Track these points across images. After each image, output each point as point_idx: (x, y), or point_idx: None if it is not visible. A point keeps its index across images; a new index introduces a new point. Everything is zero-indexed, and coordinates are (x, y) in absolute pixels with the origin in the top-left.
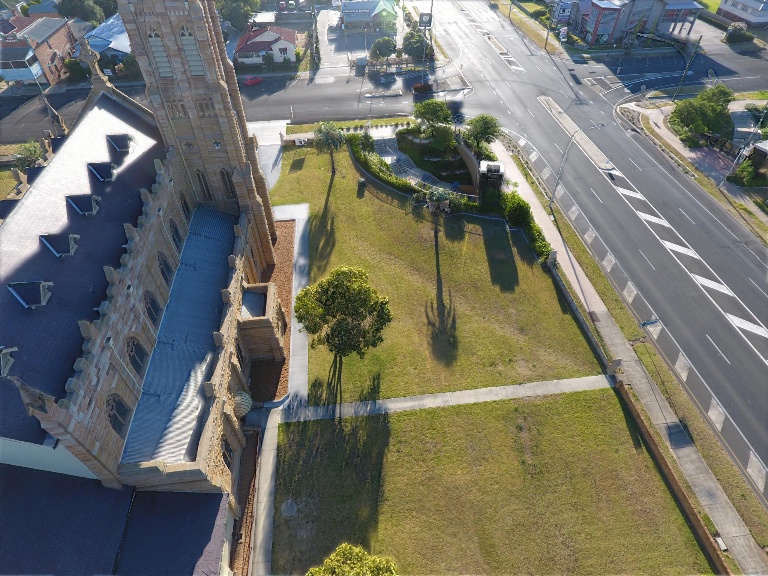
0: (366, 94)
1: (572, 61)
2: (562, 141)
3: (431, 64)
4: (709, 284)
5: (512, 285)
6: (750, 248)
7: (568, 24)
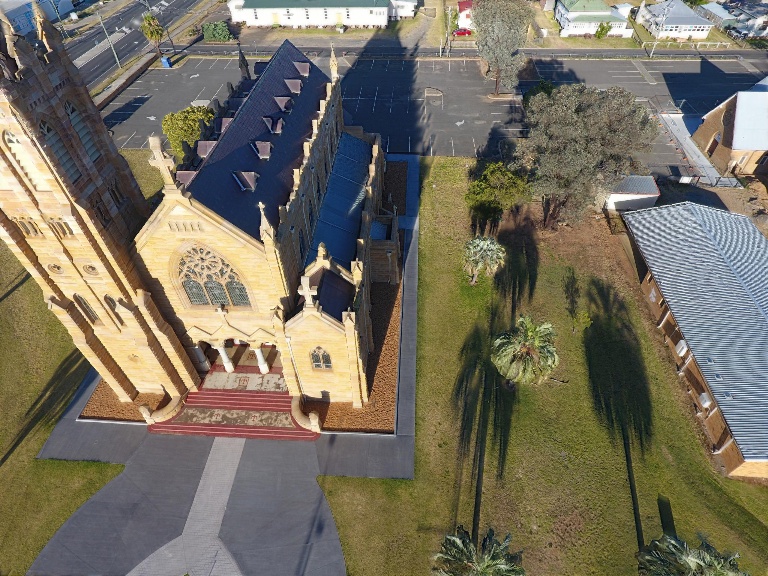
0: None
1: None
2: None
3: None
4: None
5: None
6: None
7: None
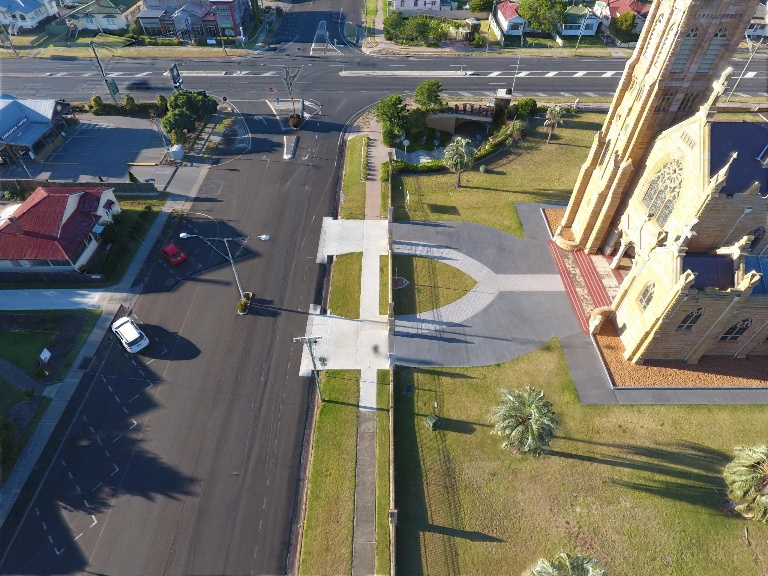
0: (284, 157)
1: (267, 51)
2: (422, 80)
3: (220, 113)
4: (581, 74)
5: (598, 125)
6: (544, 60)
7: (182, 34)
